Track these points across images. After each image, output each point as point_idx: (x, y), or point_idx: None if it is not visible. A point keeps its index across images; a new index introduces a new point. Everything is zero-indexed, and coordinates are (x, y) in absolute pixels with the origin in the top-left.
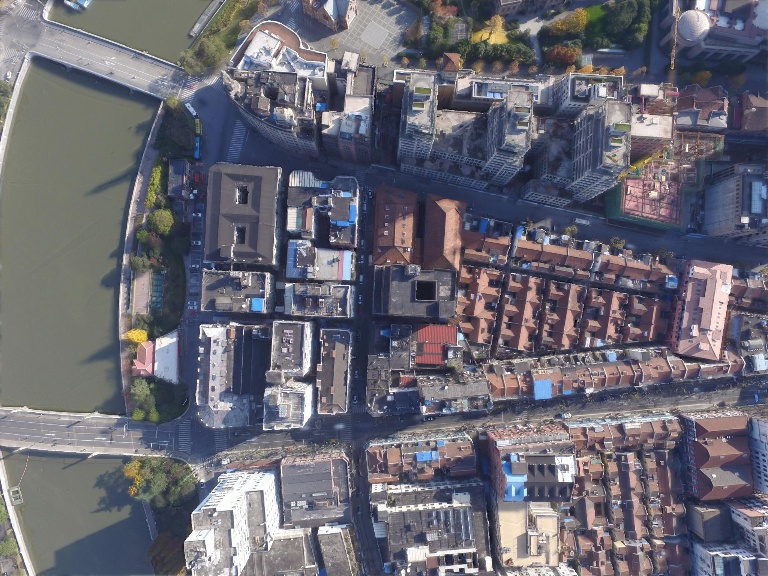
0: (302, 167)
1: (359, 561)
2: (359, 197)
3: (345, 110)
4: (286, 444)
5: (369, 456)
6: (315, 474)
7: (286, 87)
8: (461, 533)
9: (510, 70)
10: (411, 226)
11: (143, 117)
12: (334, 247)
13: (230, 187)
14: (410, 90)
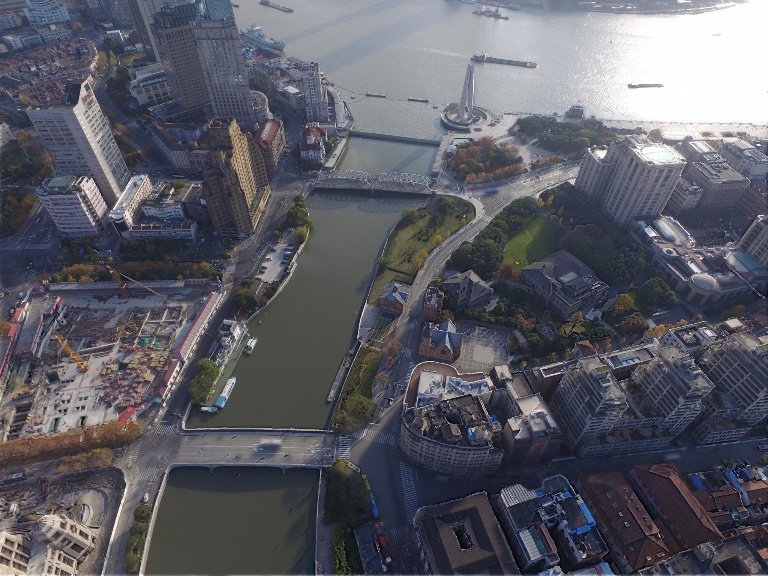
0: (486, 488)
1: None
2: None
3: (523, 412)
4: None
5: None
6: None
7: (468, 408)
8: None
9: (603, 347)
10: (642, 507)
11: (302, 494)
12: (586, 564)
13: (447, 532)
14: (588, 373)
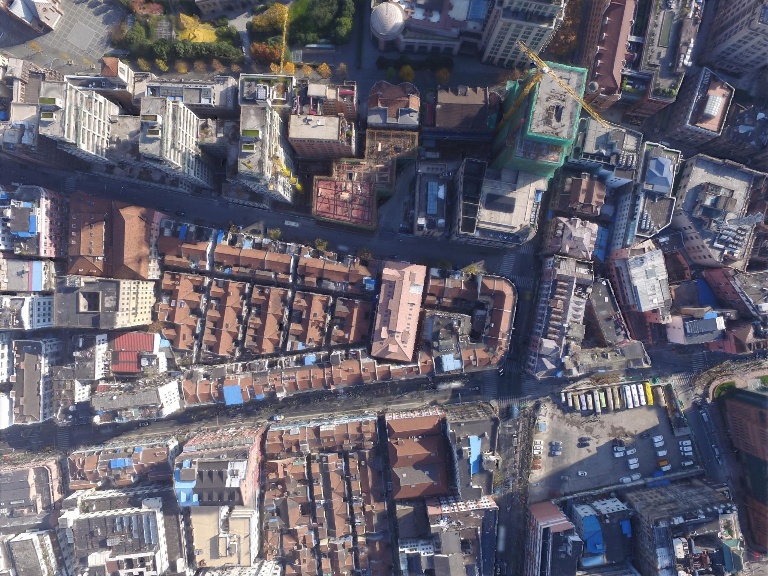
0: (10, 175)
1: (59, 565)
2: (58, 205)
3: (12, 119)
4: (4, 452)
5: (71, 463)
6: (12, 483)
7: None
8: (144, 537)
9: None
10: (101, 234)
11: None
12: (24, 258)
13: None
14: None
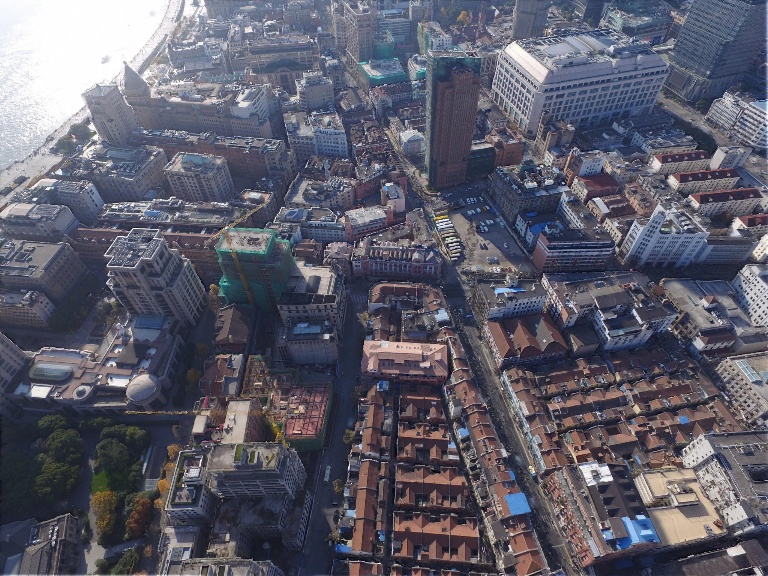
0: None
1: None
2: None
3: None
4: None
5: None
6: None
7: None
8: None
9: None
10: None
11: None
12: None
13: None
14: None
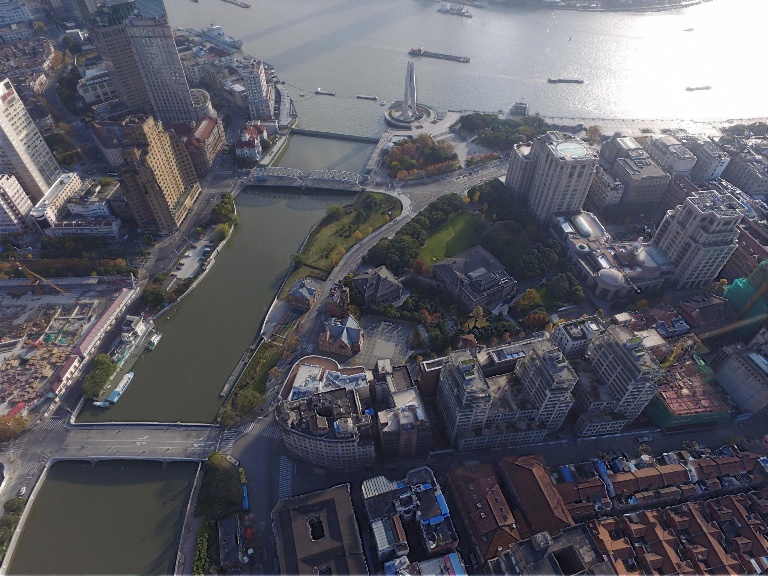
0: (361, 481)
1: None
2: None
3: (396, 405)
4: None
5: None
6: None
7: (339, 401)
8: None
9: (503, 341)
10: (503, 498)
11: (178, 487)
12: (435, 554)
13: (301, 523)
14: (455, 366)
